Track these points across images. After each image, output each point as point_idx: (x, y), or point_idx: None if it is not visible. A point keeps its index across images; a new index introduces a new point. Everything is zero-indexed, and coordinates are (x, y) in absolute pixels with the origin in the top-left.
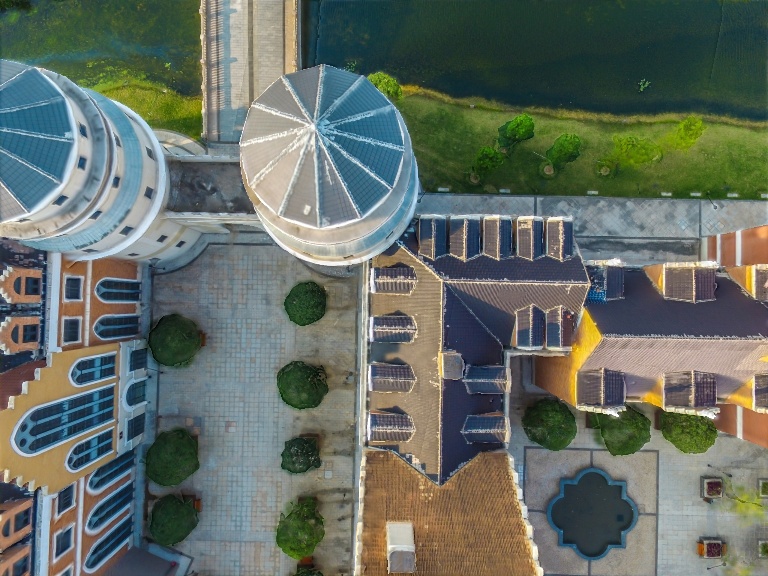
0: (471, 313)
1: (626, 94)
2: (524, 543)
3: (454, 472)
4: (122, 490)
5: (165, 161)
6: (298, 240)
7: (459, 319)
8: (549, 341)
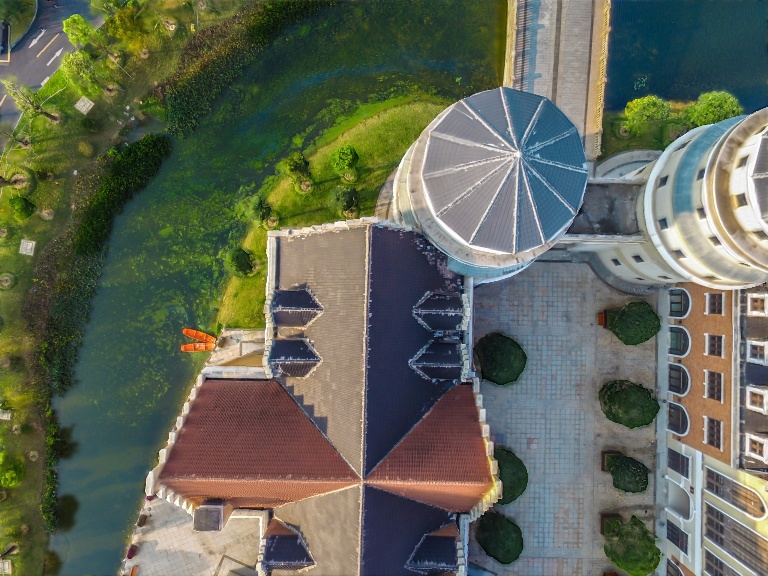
0: None
1: None
2: None
3: None
4: None
5: None
6: (760, 269)
7: None
8: None
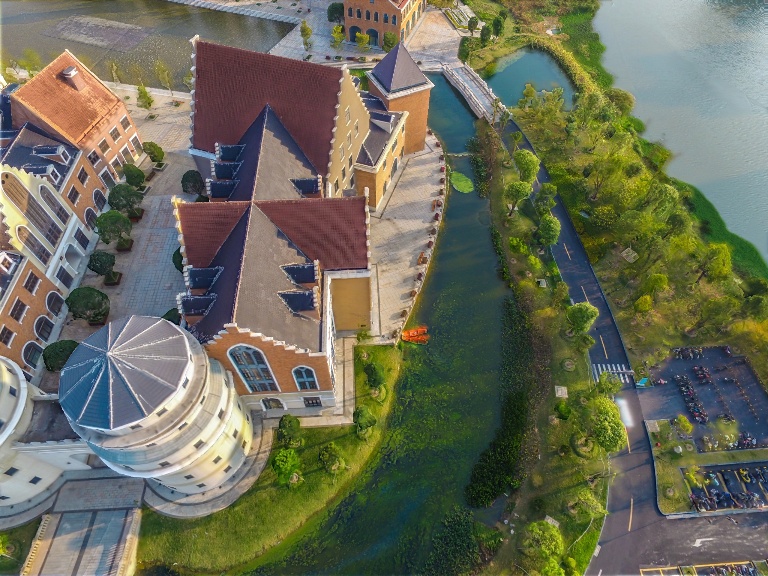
0: None
1: None
2: None
3: None
4: None
5: None
6: None
7: None
8: None
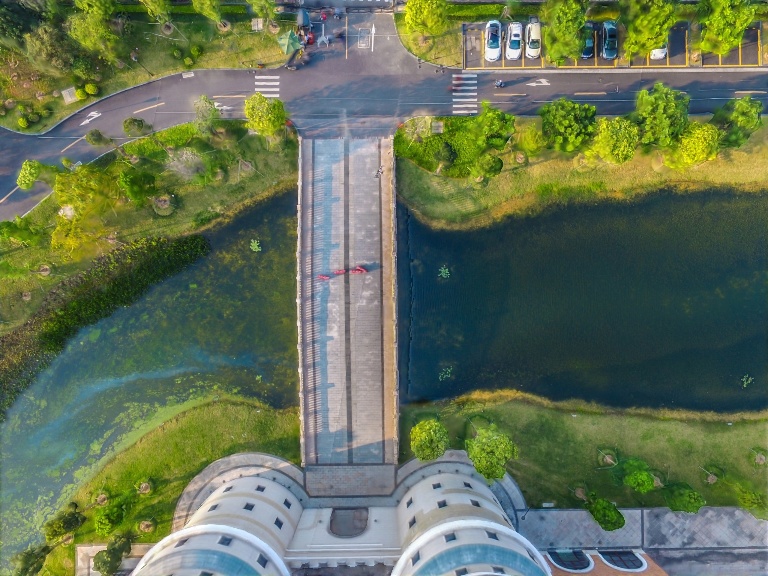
0: None
1: (729, 390)
2: None
3: None
4: None
5: (290, 573)
6: None
7: None
8: None
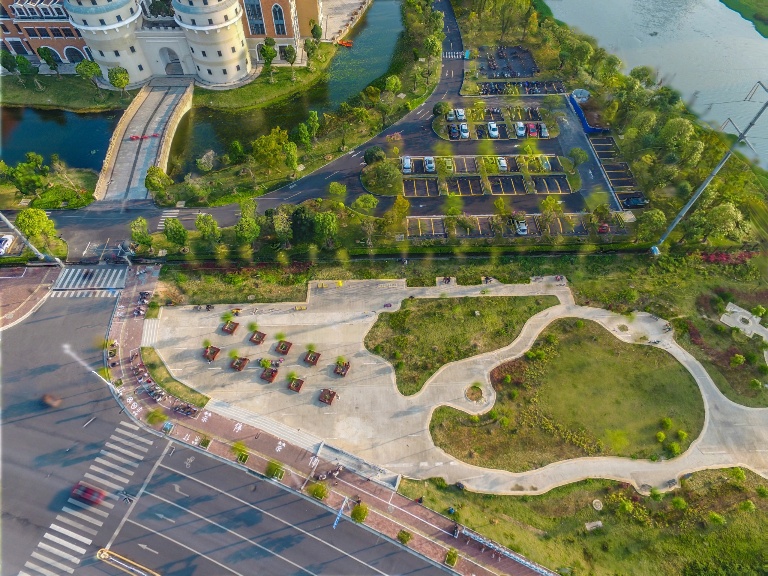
0: None
1: None
2: None
3: None
4: None
5: None
6: None
7: None
8: None
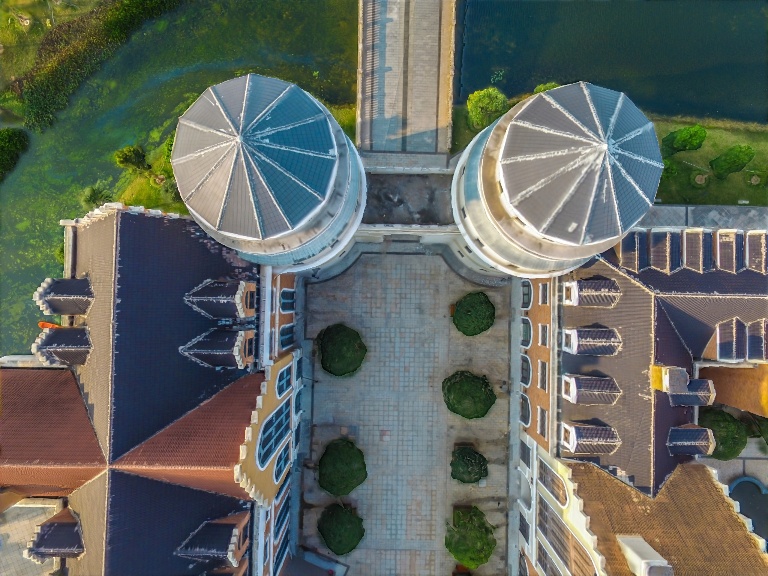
0: (672, 326)
1: None
2: (760, 557)
3: (662, 484)
4: (286, 499)
5: None
6: (533, 255)
7: (664, 332)
8: (751, 354)
